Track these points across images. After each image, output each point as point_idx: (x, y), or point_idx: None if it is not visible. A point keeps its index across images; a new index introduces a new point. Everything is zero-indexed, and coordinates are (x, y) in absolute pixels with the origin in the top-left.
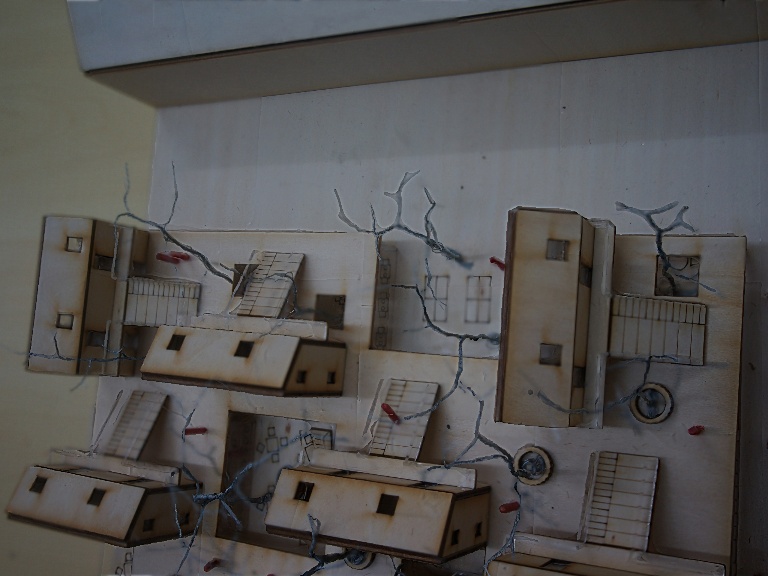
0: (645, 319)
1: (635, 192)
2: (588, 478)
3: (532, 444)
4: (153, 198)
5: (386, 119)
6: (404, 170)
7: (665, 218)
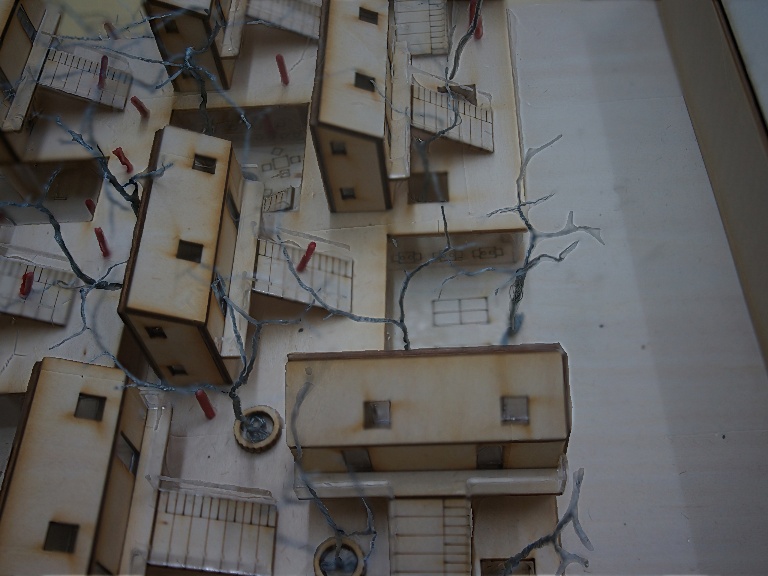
0: (444, 544)
1: (622, 535)
2: (237, 487)
3: (284, 426)
4: (548, 7)
5: (676, 231)
6: (615, 259)
7: (592, 575)
